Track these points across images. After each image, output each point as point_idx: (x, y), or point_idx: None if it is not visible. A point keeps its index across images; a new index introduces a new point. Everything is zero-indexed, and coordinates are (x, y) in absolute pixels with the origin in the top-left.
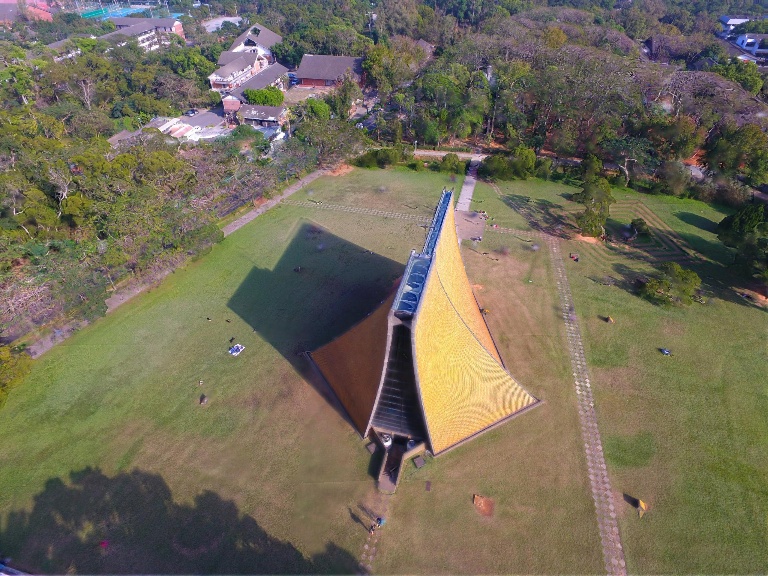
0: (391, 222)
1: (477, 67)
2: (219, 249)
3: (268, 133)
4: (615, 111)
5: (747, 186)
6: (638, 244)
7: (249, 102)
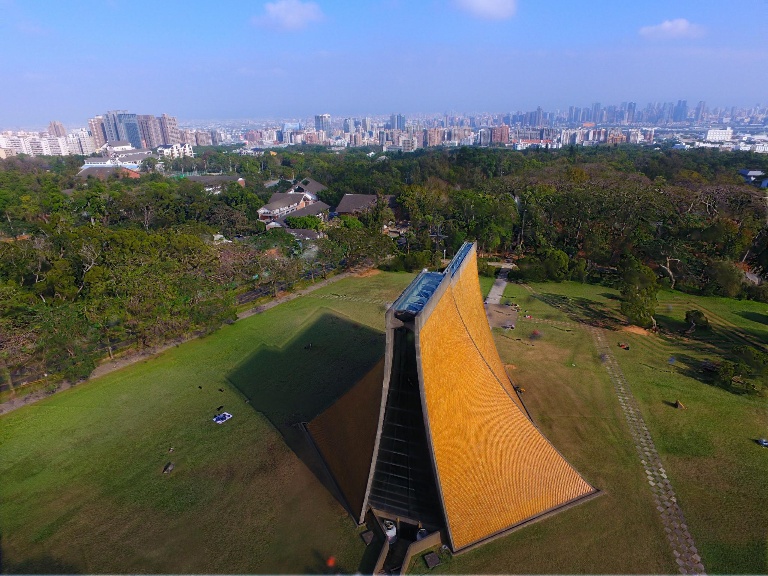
0: None
1: None
2: (231, 329)
3: None
4: (648, 218)
5: None
6: (698, 337)
7: (290, 227)
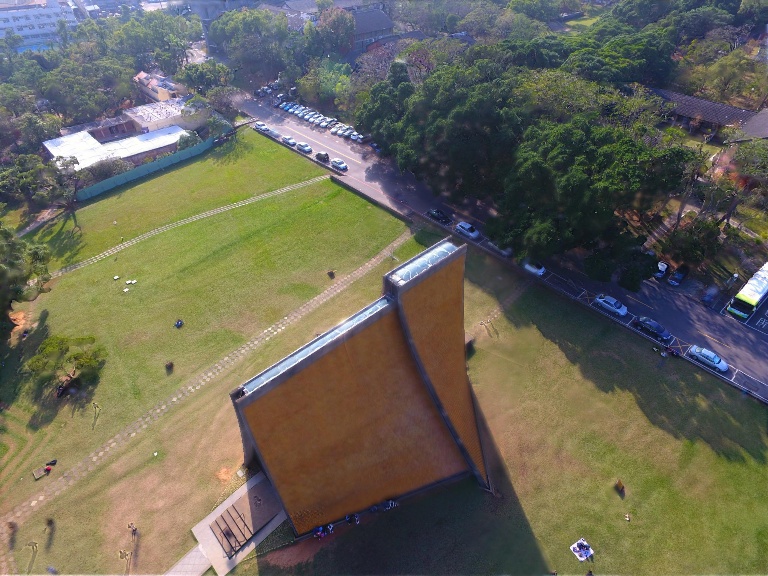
0: None
1: None
2: None
3: None
4: None
5: None
6: None
7: None
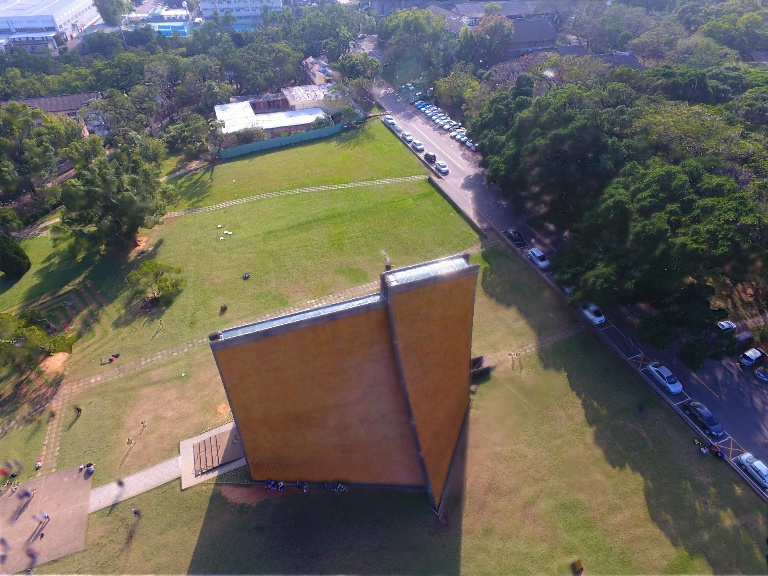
0: None
1: None
2: None
3: None
4: None
5: None
6: (61, 321)
7: None
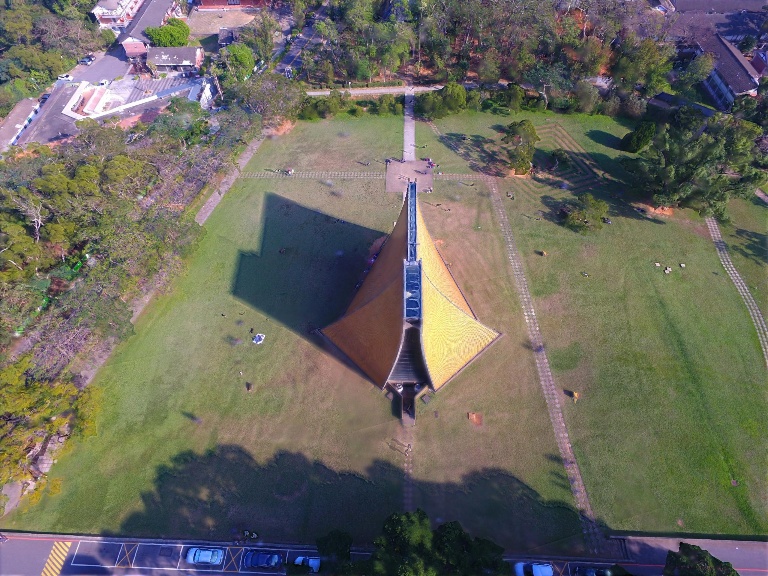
0: (350, 184)
1: None
2: (202, 241)
3: (195, 90)
4: (531, 34)
5: (643, 100)
6: (559, 172)
7: (154, 43)
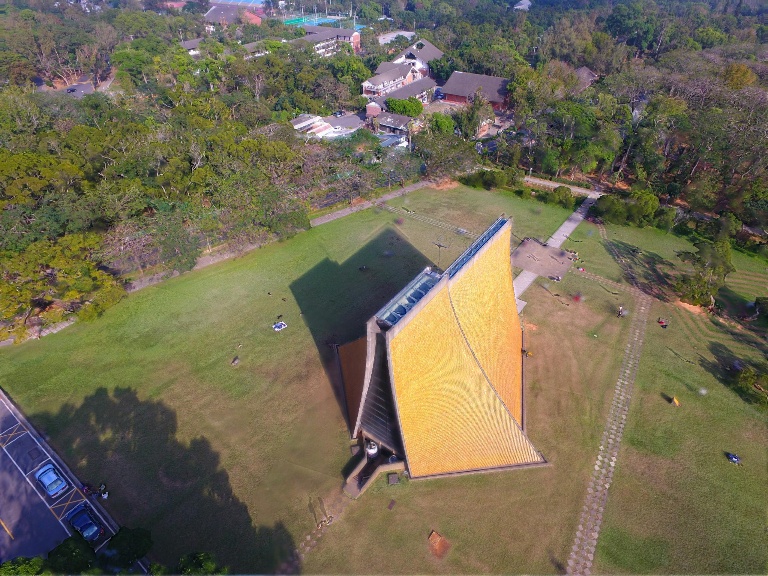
0: None
1: (632, 101)
2: (305, 236)
3: (391, 140)
4: None
5: None
6: (756, 327)
7: (389, 110)
